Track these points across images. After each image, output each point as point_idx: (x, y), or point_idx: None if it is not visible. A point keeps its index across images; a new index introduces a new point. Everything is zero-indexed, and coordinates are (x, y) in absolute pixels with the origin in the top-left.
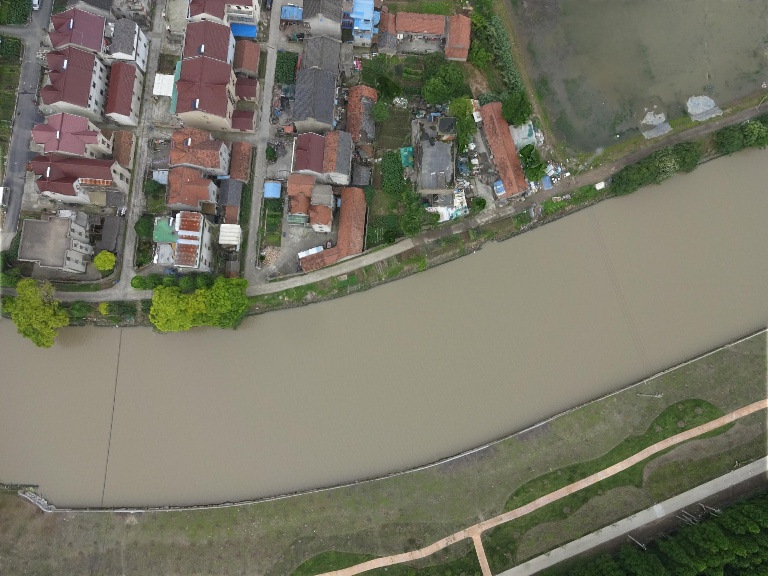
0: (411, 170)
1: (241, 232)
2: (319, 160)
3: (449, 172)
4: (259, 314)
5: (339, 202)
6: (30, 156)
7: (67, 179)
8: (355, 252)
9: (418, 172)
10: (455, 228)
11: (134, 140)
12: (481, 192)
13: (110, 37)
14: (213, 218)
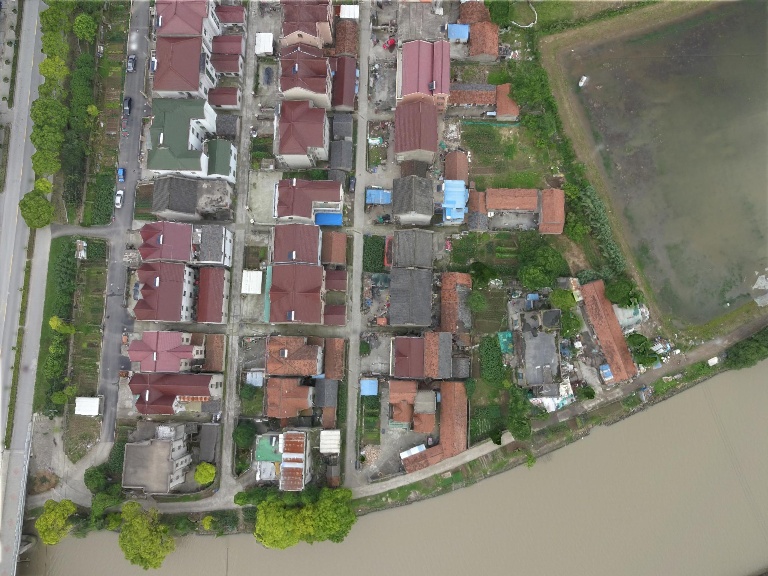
0: (511, 356)
1: (340, 433)
2: (419, 363)
3: (555, 365)
4: (362, 515)
5: (439, 397)
6: (122, 361)
7: (165, 399)
8: (459, 451)
9: (521, 365)
10: (561, 415)
11: (225, 340)
12: (586, 375)
13: (198, 244)
14: (310, 419)
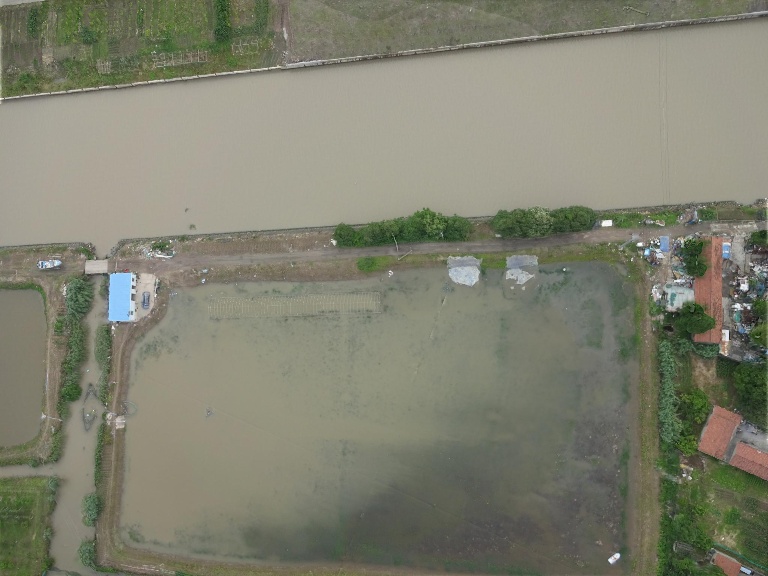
0: None
1: None
2: None
3: None
4: None
5: None
6: None
7: None
8: None
9: None
10: None
11: None
12: (742, 256)
13: None
14: None
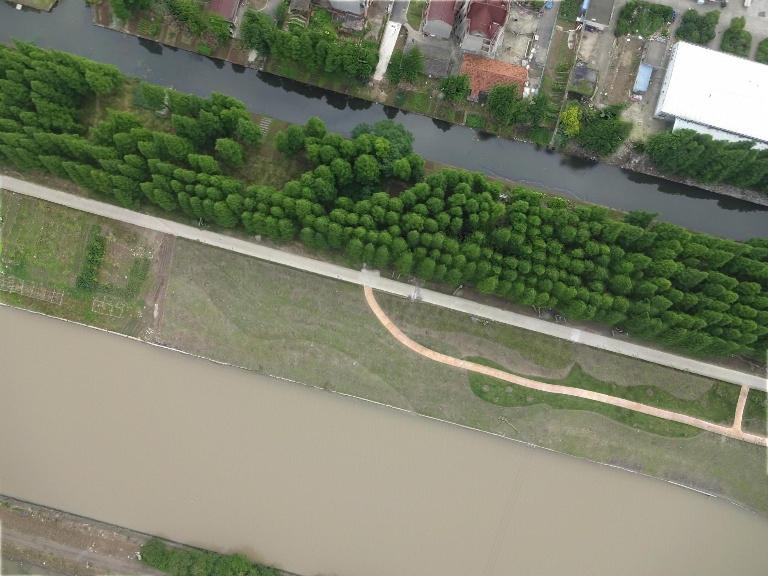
0: None
1: None
2: None
3: None
4: None
5: None
6: None
7: None
8: None
9: None
10: None
11: None
12: None
13: None
14: None
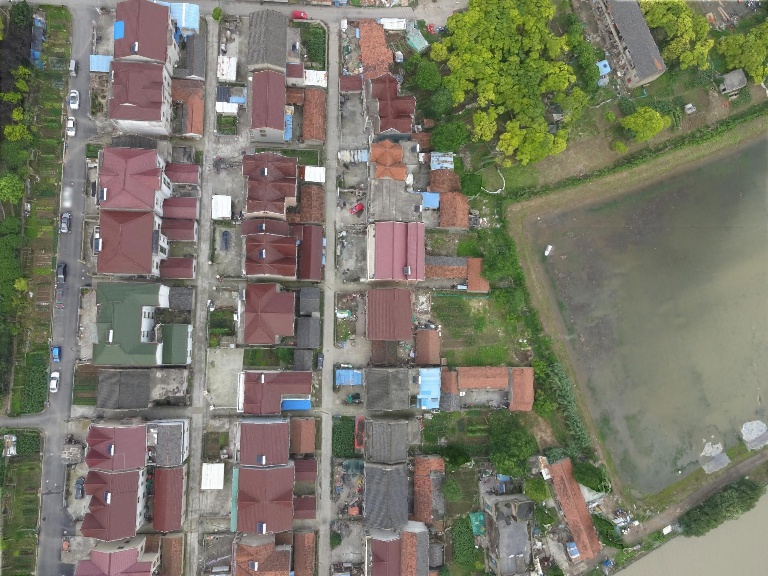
0: (482, 537)
1: None
2: (396, 565)
3: (527, 552)
4: None
5: None
6: (62, 569)
7: None
8: None
9: None
10: None
11: (183, 540)
12: (553, 551)
13: (154, 445)
14: None
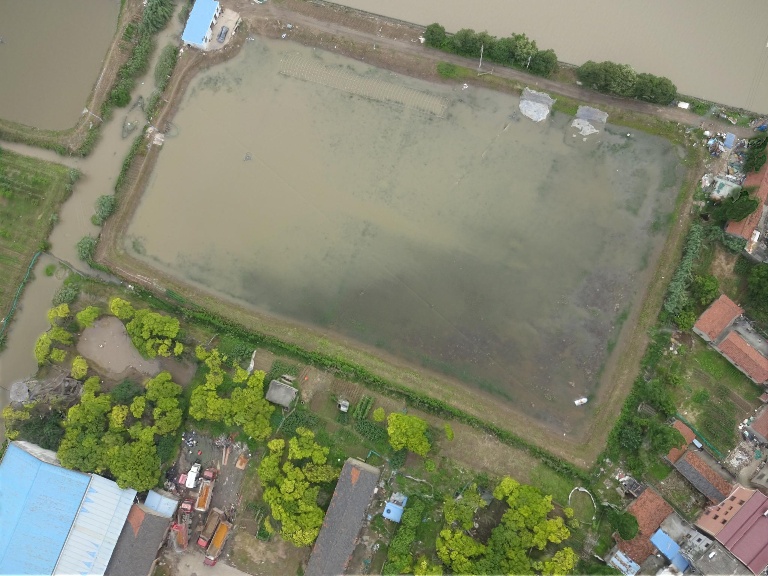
0: None
1: None
2: None
3: None
4: None
5: None
6: None
7: None
8: None
9: None
10: None
11: None
12: None
13: None
14: None
